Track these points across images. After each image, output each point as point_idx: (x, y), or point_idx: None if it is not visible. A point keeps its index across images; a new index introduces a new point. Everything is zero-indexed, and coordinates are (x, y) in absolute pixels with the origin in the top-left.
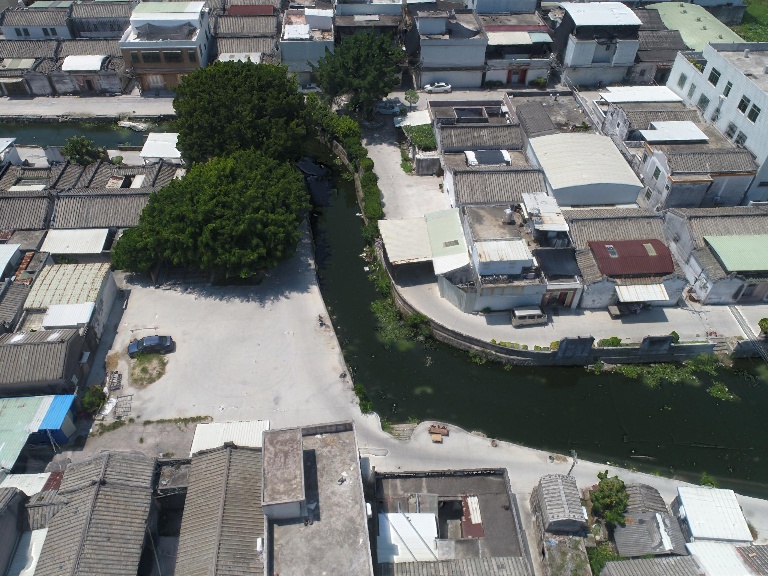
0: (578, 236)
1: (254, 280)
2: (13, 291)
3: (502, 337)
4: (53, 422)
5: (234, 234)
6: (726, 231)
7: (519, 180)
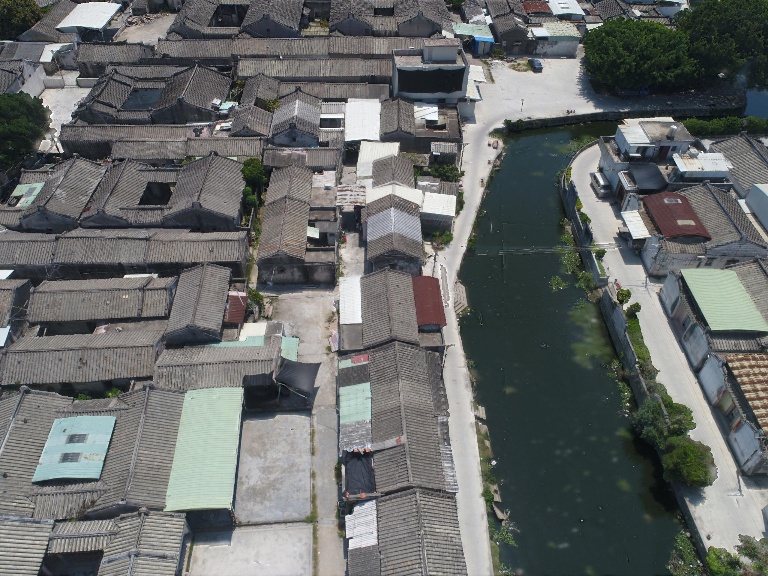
0: (690, 192)
1: (599, 91)
2: (552, 19)
3: (579, 177)
4: (479, 39)
5: (603, 44)
6: (754, 292)
7: (760, 170)
